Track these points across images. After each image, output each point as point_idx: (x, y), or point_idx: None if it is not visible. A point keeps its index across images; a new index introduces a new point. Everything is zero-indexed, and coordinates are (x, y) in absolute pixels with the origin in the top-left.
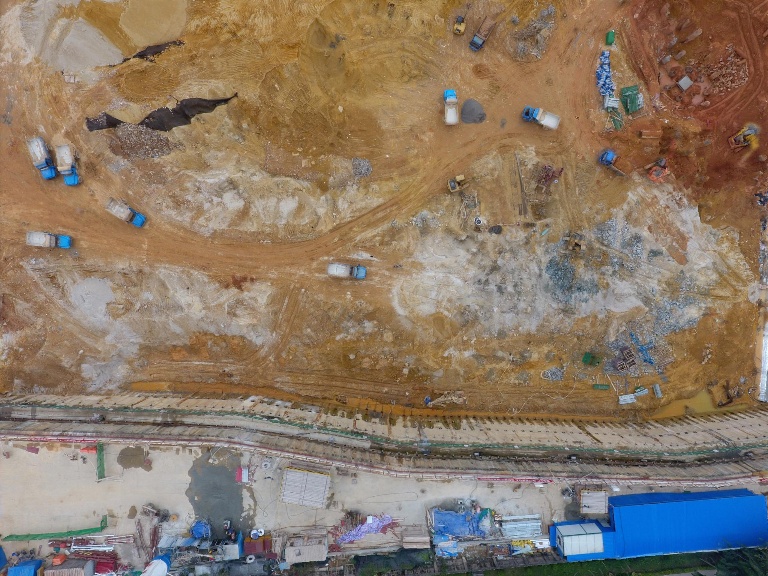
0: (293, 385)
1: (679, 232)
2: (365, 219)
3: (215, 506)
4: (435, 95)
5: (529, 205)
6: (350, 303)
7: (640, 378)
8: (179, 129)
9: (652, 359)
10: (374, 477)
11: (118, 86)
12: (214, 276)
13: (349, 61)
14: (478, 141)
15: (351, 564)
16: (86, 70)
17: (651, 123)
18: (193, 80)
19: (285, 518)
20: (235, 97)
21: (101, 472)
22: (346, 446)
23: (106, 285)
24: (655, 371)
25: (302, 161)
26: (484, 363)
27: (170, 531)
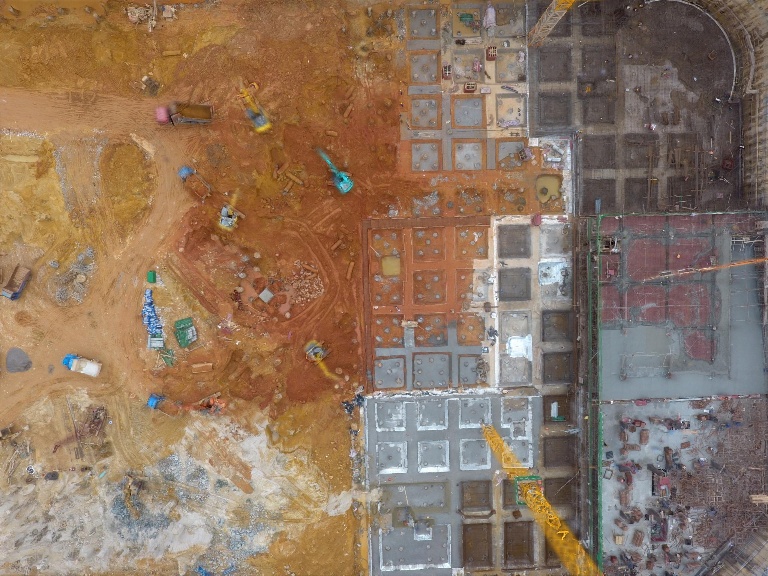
0: None
1: (241, 462)
2: None
3: None
4: None
5: (85, 448)
6: None
7: None
8: None
9: None
10: None
11: None
12: None
13: None
14: (26, 389)
15: None
16: None
17: (211, 352)
18: None
19: None
20: None
21: None
22: None
23: None
24: None
25: None
26: None
27: None
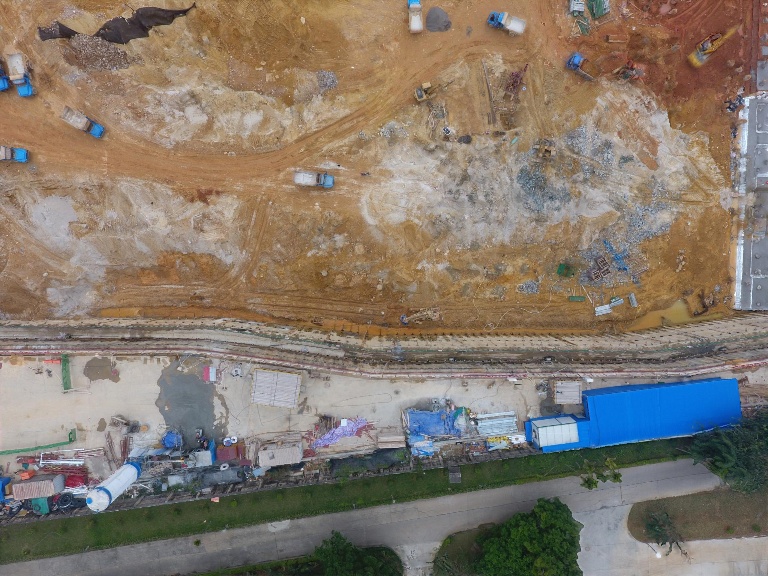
0: (266, 307)
1: (649, 137)
2: (331, 130)
3: (186, 415)
4: (399, 4)
5: (498, 114)
6: (319, 214)
7: (615, 288)
8: (137, 42)
9: (627, 268)
10: (347, 380)
11: None
12: (178, 189)
13: None
14: (444, 50)
15: (327, 467)
16: None
17: (618, 28)
18: None
19: (258, 425)
20: (193, 8)
21: (67, 384)
22: (319, 354)
23: (68, 203)
24: (630, 280)
25: (266, 75)
26: (459, 278)
27: (141, 442)
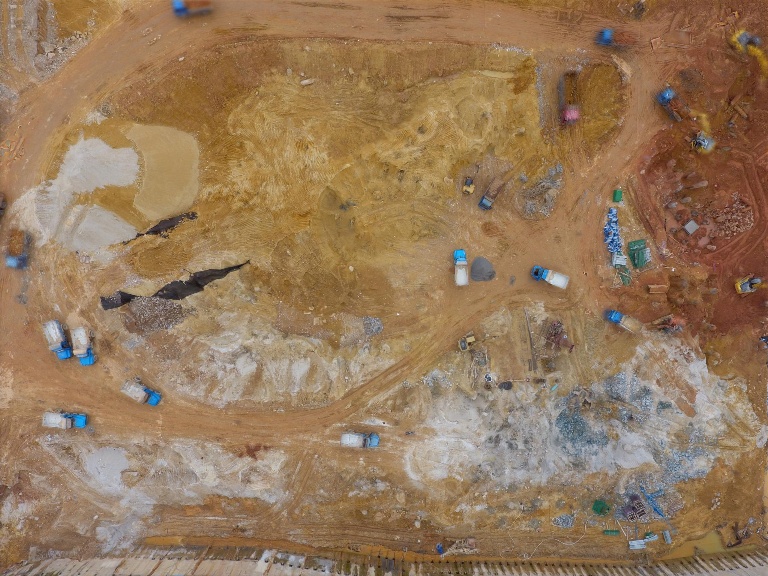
0: (306, 537)
1: (687, 385)
2: (377, 382)
3: None
4: (445, 253)
5: (539, 360)
6: (363, 469)
7: (650, 524)
8: (192, 297)
9: (662, 506)
10: None
11: (132, 264)
12: (228, 447)
13: (360, 226)
14: (488, 298)
15: None
16: (101, 251)
17: (658, 275)
18: (206, 252)
19: None
20: (247, 264)
21: None
22: None
23: (121, 454)
24: (665, 517)
25: (313, 319)
26: (495, 512)
27: None
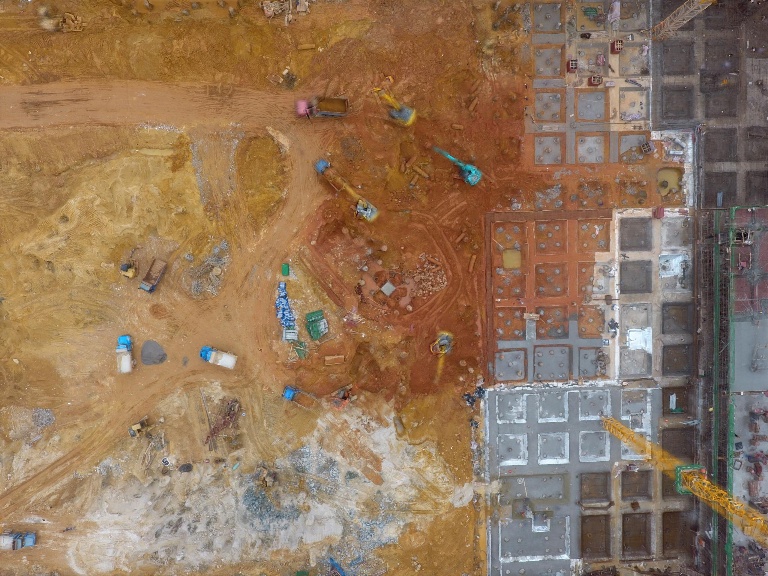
0: None
1: (372, 454)
2: (41, 477)
3: None
4: (113, 339)
5: (219, 440)
6: (26, 568)
7: None
8: None
9: (365, 571)
10: None
11: None
12: None
13: (11, 320)
14: (161, 381)
15: None
16: None
17: (340, 345)
18: None
19: None
20: None
21: None
22: None
23: None
24: None
25: None
26: None
27: None
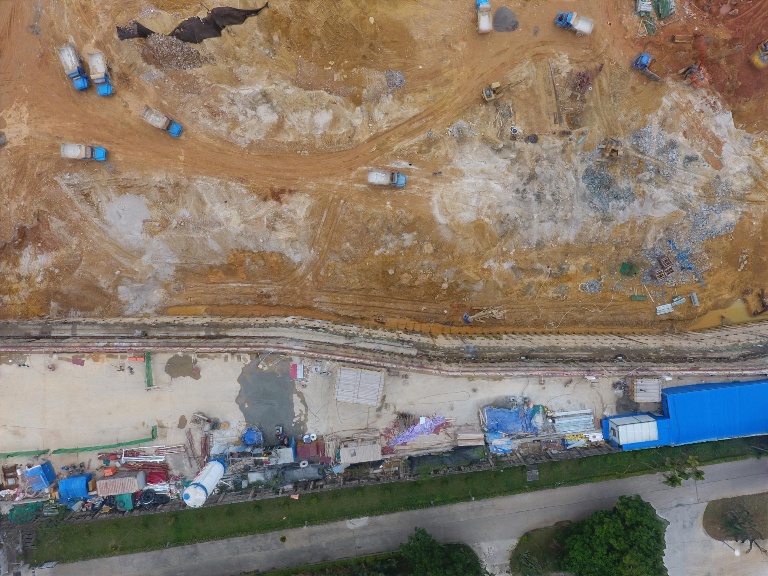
0: (331, 305)
1: (714, 137)
2: (401, 129)
3: (266, 413)
4: (466, 4)
5: (564, 113)
6: (390, 212)
7: (677, 288)
8: (210, 41)
9: None
10: (425, 378)
11: None
12: (252, 188)
13: None
14: (511, 50)
15: (406, 465)
16: None
17: (683, 29)
18: None
19: (337, 422)
20: (265, 7)
21: (149, 381)
22: (393, 353)
23: (141, 202)
24: (692, 280)
25: (334, 75)
26: (522, 277)
27: (221, 439)
